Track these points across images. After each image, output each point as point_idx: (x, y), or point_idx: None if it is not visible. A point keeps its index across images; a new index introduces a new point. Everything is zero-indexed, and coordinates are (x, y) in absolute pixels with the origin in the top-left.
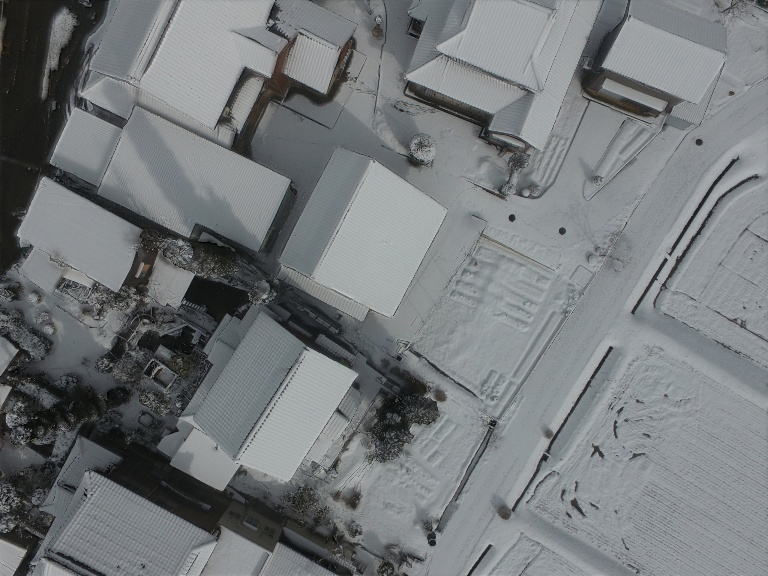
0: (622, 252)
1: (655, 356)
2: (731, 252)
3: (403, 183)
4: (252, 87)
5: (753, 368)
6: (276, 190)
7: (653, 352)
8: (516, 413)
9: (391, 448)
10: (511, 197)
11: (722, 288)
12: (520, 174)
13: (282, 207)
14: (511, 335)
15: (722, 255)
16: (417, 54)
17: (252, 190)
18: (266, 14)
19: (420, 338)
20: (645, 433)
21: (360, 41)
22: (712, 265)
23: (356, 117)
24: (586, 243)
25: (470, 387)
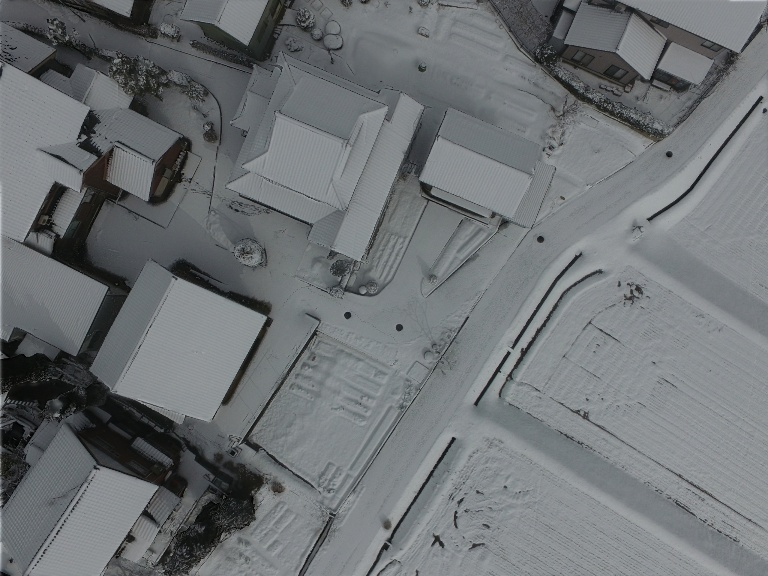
0: (463, 346)
1: (495, 448)
2: (575, 345)
3: (212, 296)
4: (73, 194)
5: (593, 460)
6: (93, 297)
7: (493, 444)
8: (356, 504)
9: (180, 566)
10: (346, 295)
11: (566, 380)
12: (359, 271)
13: (103, 311)
14: (349, 428)
15: (566, 348)
16: (238, 164)
17: (70, 296)
18: (76, 130)
19: (259, 430)
20: (485, 524)
21: (195, 143)
22: (556, 357)
23: (191, 216)
24: (423, 339)
25: (308, 479)
